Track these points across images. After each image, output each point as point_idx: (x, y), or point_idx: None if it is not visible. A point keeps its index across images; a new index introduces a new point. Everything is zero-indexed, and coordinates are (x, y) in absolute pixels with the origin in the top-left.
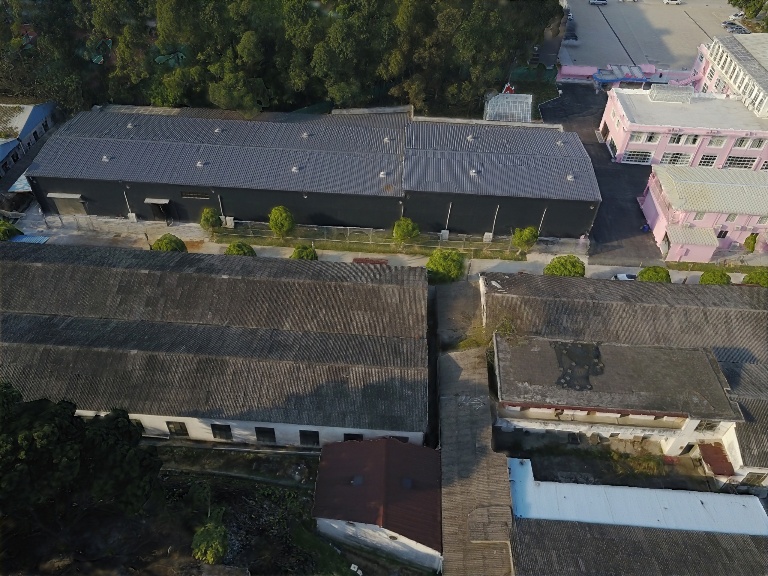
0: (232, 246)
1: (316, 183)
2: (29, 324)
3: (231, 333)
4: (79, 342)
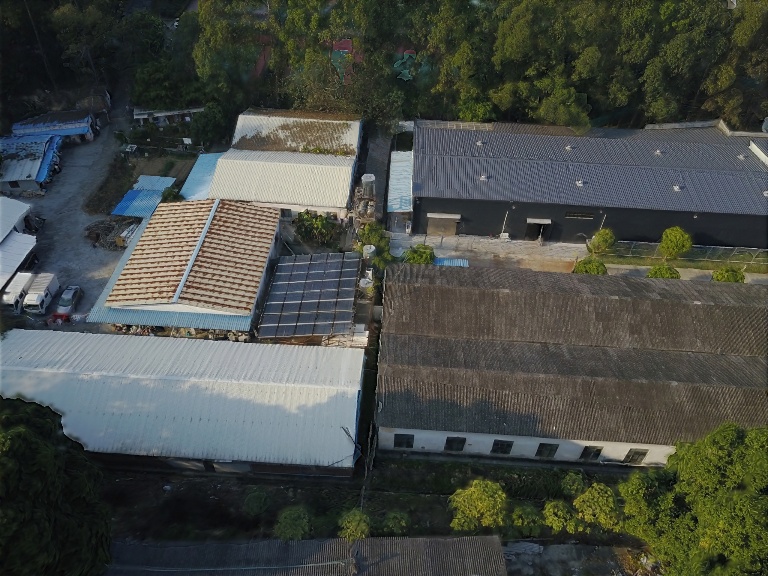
0: (664, 269)
1: (707, 203)
2: (533, 353)
3: (736, 362)
4: (608, 373)
